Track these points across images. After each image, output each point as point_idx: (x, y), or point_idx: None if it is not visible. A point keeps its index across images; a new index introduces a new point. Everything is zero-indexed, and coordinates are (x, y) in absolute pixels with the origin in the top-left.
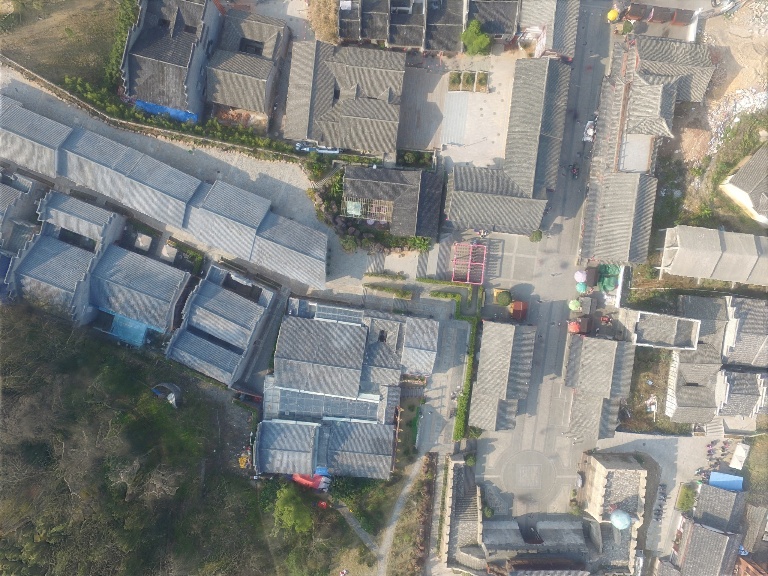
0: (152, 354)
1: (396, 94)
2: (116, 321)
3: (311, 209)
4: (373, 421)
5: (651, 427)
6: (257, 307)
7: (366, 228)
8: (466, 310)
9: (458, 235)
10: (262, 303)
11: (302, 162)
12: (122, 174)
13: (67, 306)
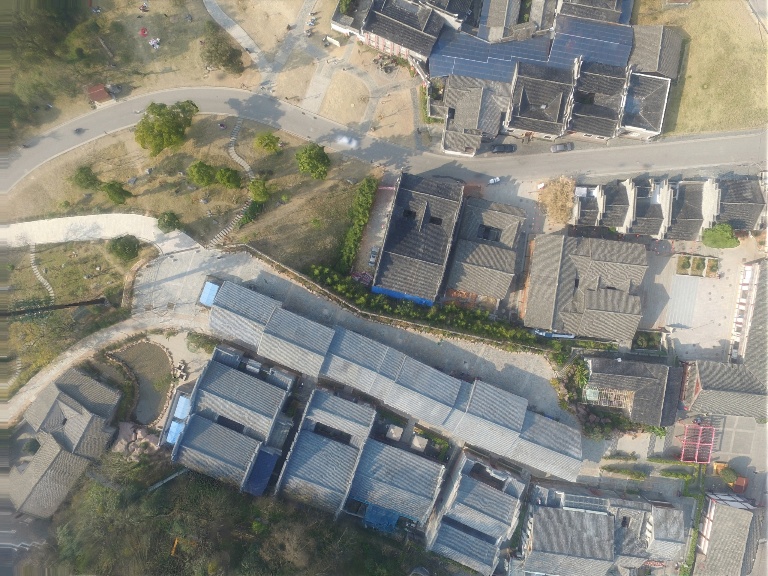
0: (398, 536)
1: (635, 284)
2: (369, 509)
3: (554, 397)
4: None
5: None
6: (510, 499)
7: (600, 410)
8: (688, 484)
9: (682, 412)
10: (511, 492)
11: (547, 353)
12: (388, 378)
13: (331, 502)
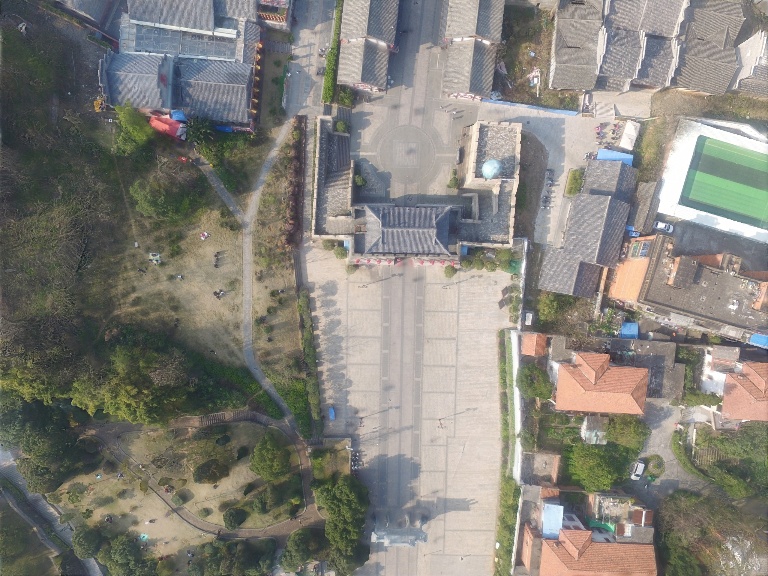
0: None
1: None
2: None
3: None
4: (231, 59)
5: (533, 99)
6: None
7: None
8: None
9: None
10: None
11: None
12: None
13: None
